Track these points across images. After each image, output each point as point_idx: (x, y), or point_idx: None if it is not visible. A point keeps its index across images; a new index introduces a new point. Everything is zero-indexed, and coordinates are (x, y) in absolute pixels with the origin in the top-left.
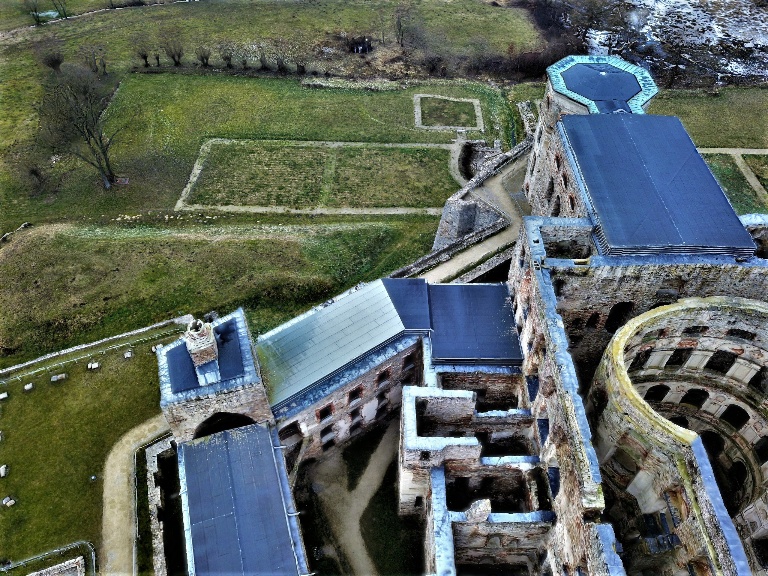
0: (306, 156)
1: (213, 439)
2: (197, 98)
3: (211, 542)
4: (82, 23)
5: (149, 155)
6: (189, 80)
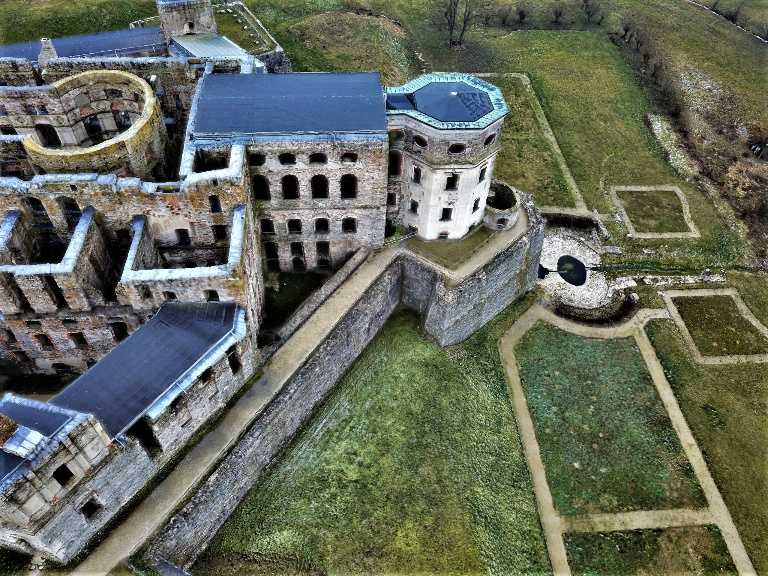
0: (524, 122)
1: (161, 30)
2: (583, 63)
3: (109, 34)
4: (670, 1)
5: (492, 53)
6: (611, 57)
